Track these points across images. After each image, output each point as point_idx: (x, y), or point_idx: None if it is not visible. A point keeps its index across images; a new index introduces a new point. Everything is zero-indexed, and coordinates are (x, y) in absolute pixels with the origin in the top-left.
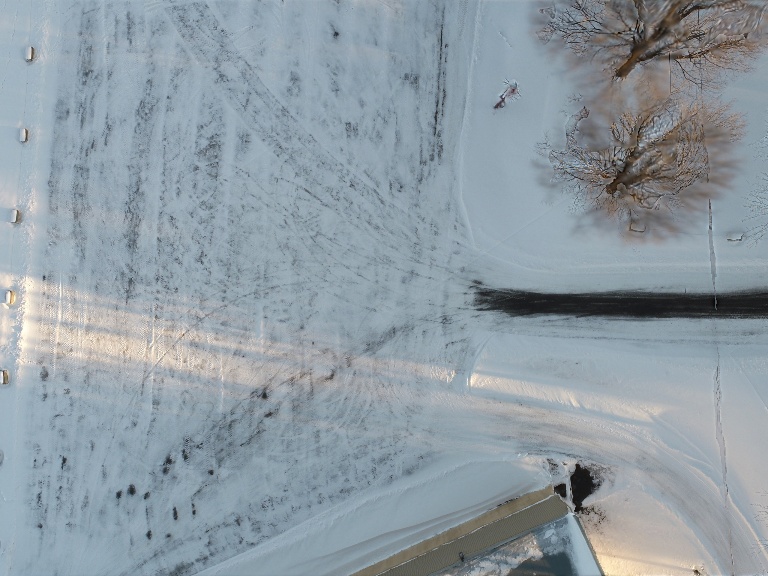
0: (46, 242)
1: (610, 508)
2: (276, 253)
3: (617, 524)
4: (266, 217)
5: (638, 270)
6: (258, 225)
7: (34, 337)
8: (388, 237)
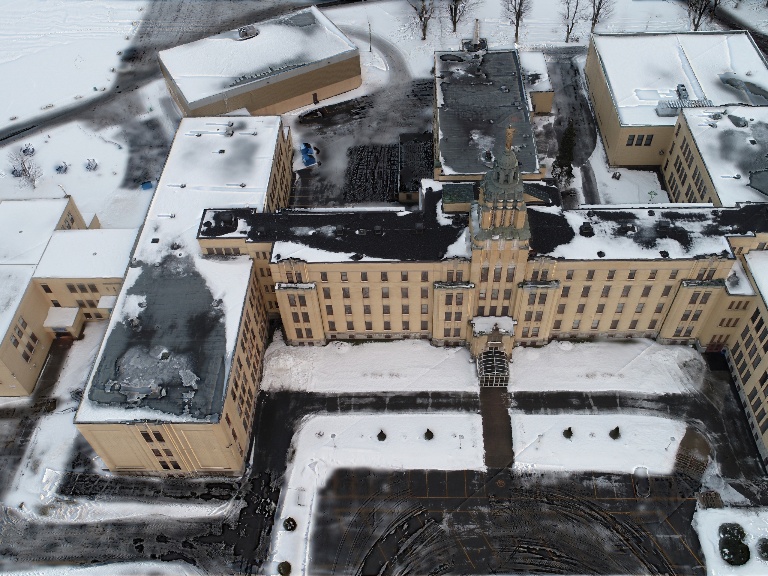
0: None
1: None
2: (227, 8)
3: None
4: (224, 2)
5: None
6: (222, 4)
7: None
8: (265, 2)
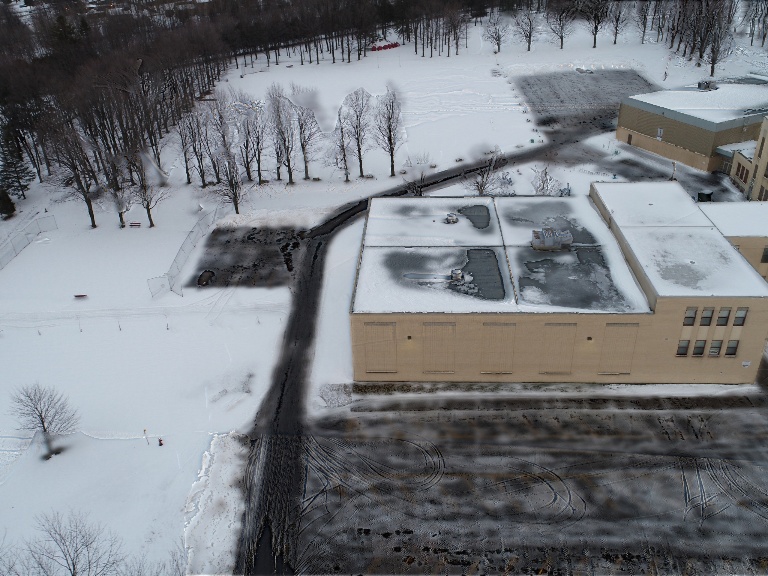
0: (529, 99)
1: None
2: None
3: None
4: None
5: None
6: None
7: None
8: (646, 92)
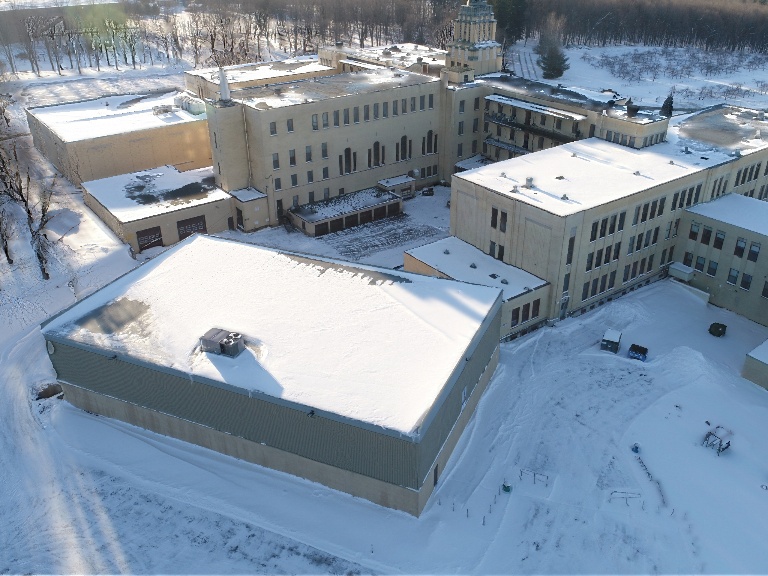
0: None
1: None
2: None
3: None
4: None
5: None
6: None
7: None
8: None
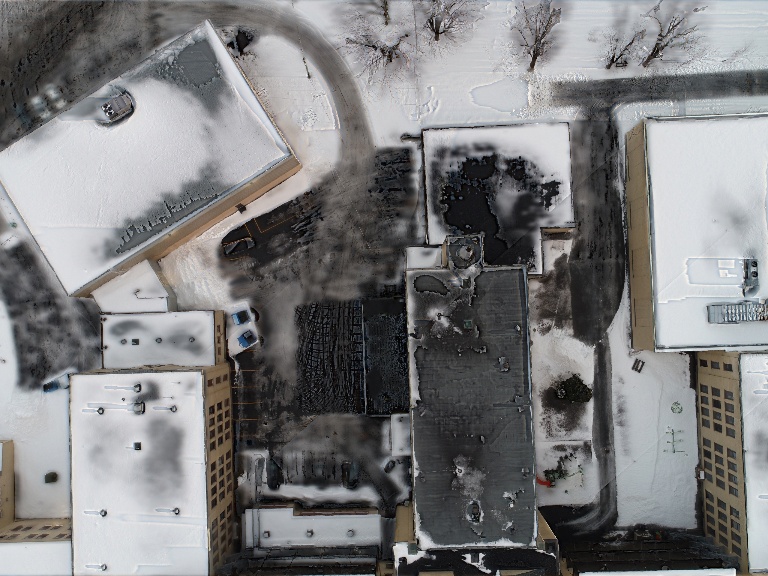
0: None
1: (259, 51)
2: None
3: (264, 59)
4: None
5: None
6: None
7: None
8: None
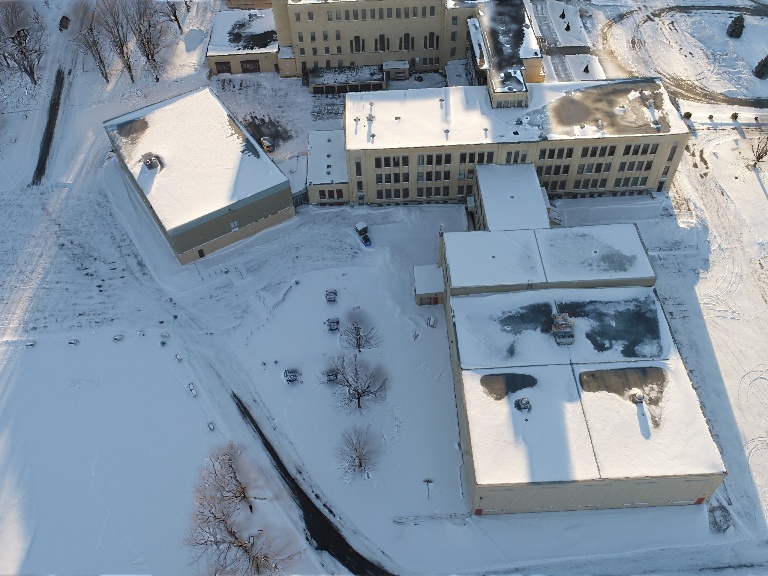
0: None
1: None
2: None
3: None
4: None
5: (33, 141)
6: None
7: (13, 335)
8: (1, 214)
